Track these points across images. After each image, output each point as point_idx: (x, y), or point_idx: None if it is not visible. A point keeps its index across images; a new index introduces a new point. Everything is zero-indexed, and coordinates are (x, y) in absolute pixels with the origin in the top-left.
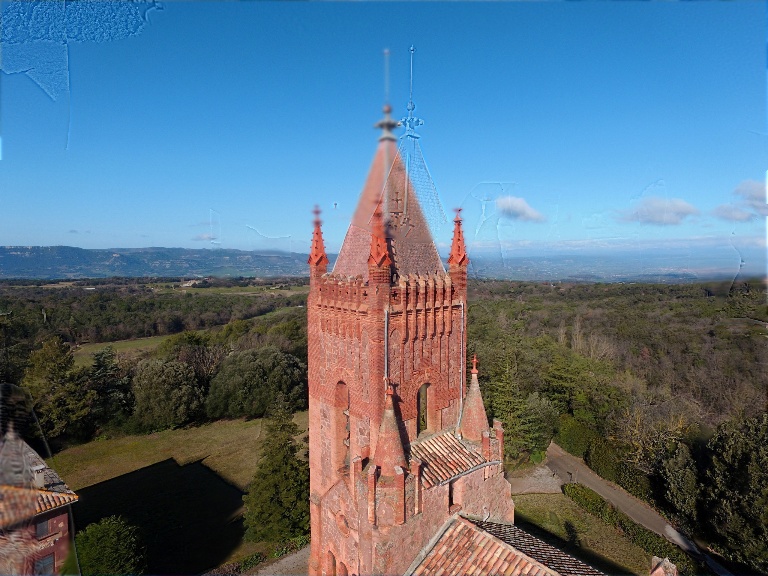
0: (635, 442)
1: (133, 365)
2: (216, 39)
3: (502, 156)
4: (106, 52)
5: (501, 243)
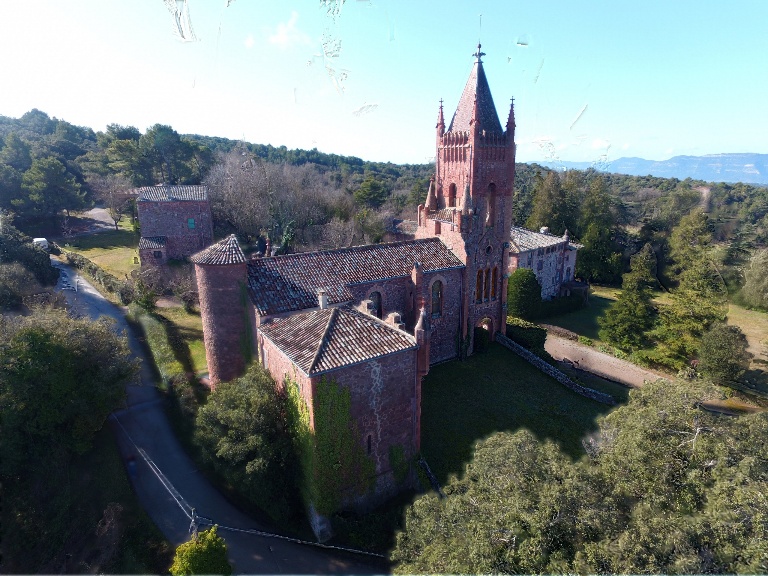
0: None
1: (766, 247)
2: None
3: (343, 103)
4: None
5: None
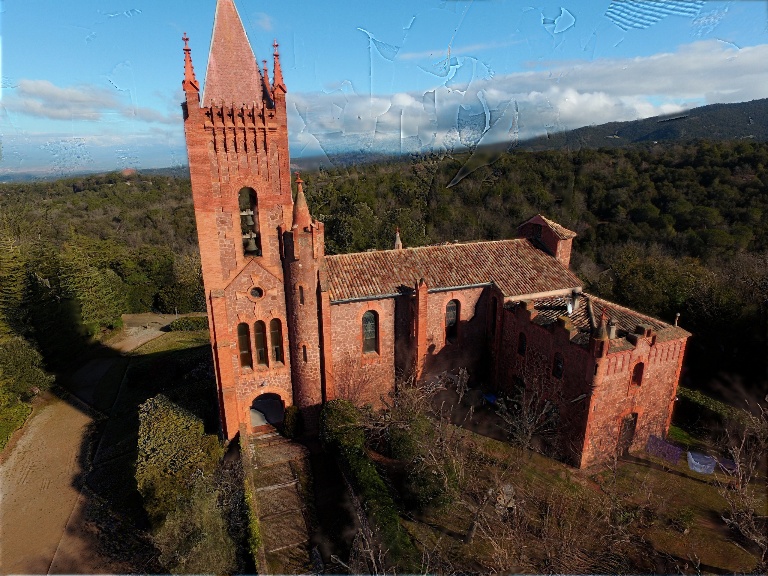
0: None
1: None
2: None
3: None
4: None
5: (6, 107)
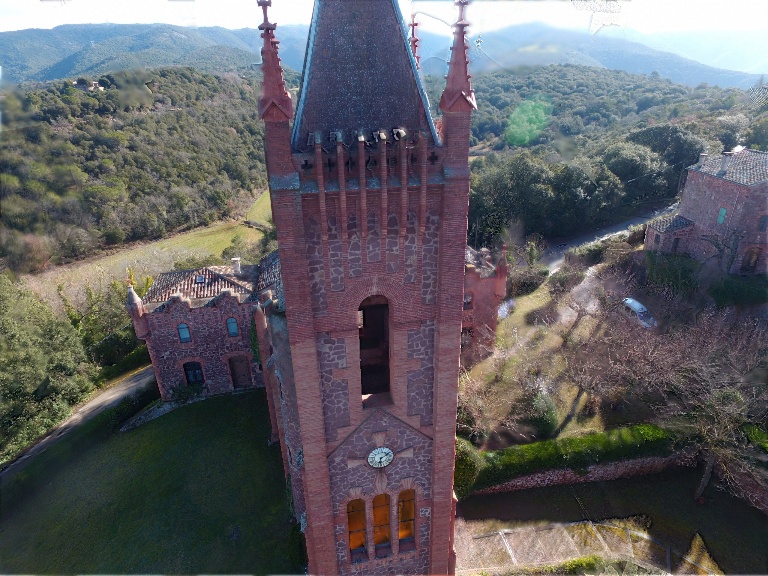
0: None
1: None
2: (547, 8)
3: None
4: (582, 14)
5: None
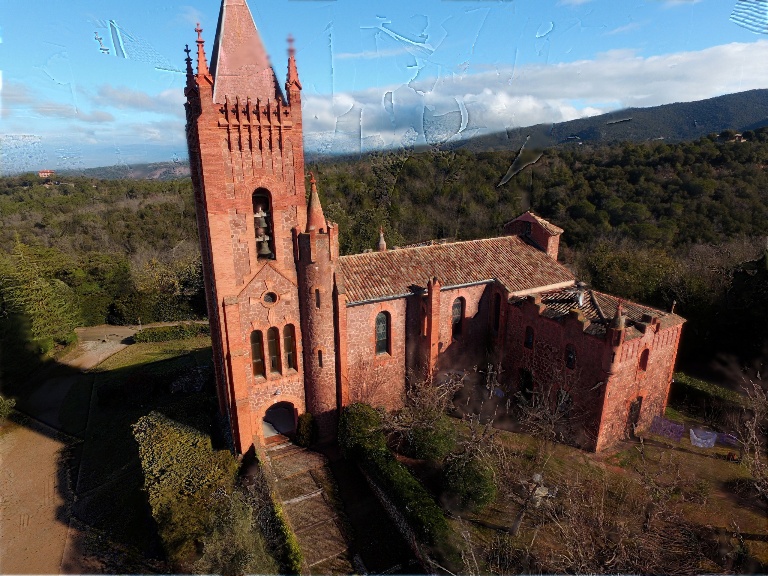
0: (172, 279)
1: None
2: None
3: None
4: None
5: None
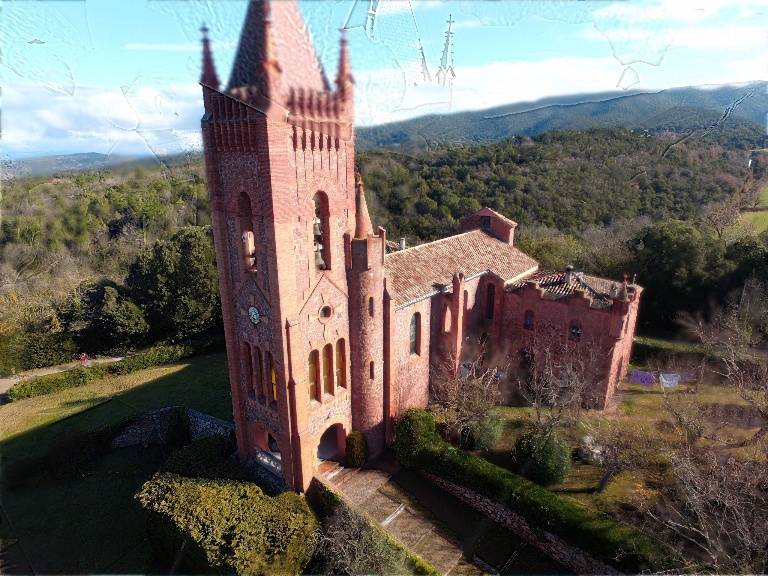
0: (49, 313)
1: None
2: None
3: None
4: None
5: None
